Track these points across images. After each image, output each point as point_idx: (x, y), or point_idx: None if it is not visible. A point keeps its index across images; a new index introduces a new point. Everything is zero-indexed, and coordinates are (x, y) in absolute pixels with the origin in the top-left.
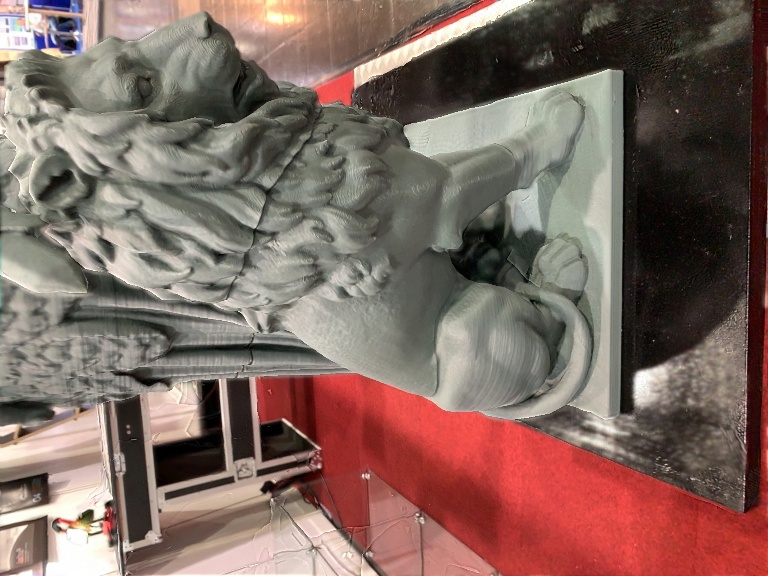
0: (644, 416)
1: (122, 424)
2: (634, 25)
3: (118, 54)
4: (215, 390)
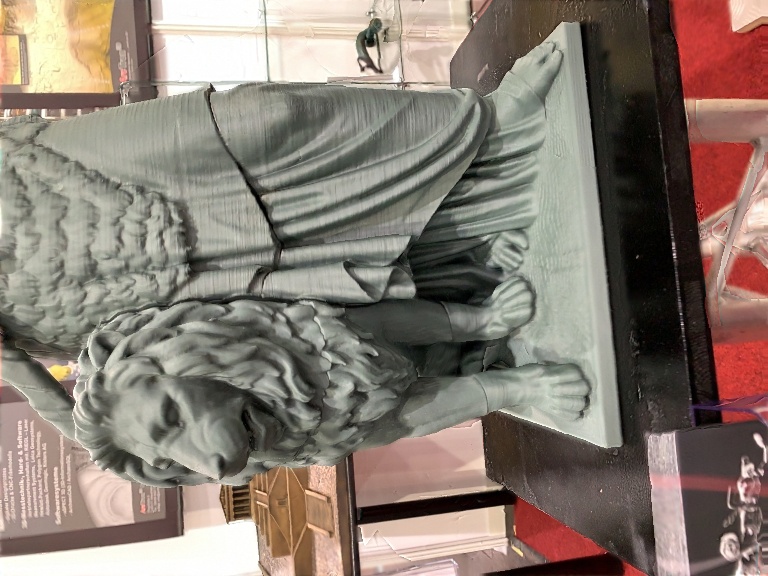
0: (495, 422)
1: None
2: (648, 466)
3: (154, 457)
4: None
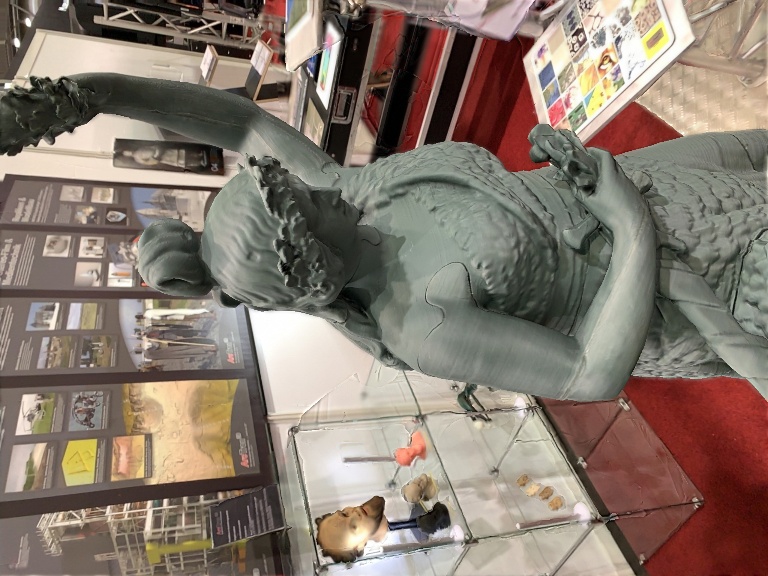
0: None
1: (329, 151)
2: None
3: None
4: (411, 143)
